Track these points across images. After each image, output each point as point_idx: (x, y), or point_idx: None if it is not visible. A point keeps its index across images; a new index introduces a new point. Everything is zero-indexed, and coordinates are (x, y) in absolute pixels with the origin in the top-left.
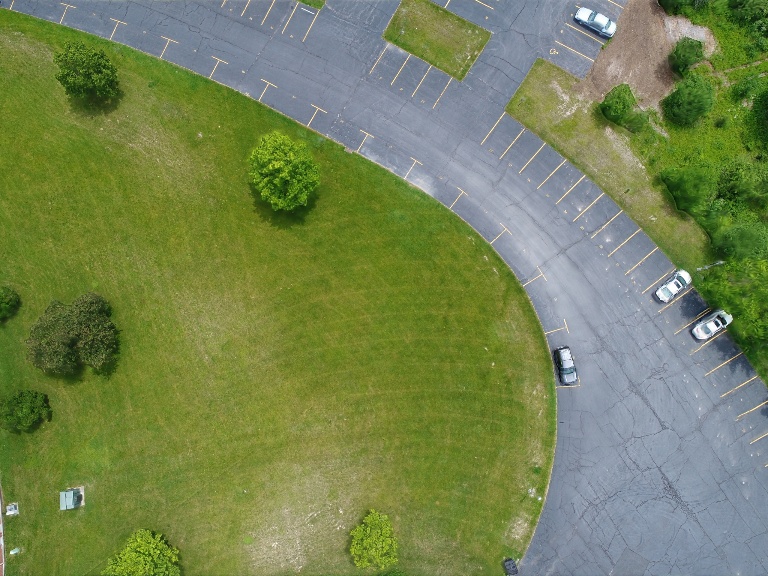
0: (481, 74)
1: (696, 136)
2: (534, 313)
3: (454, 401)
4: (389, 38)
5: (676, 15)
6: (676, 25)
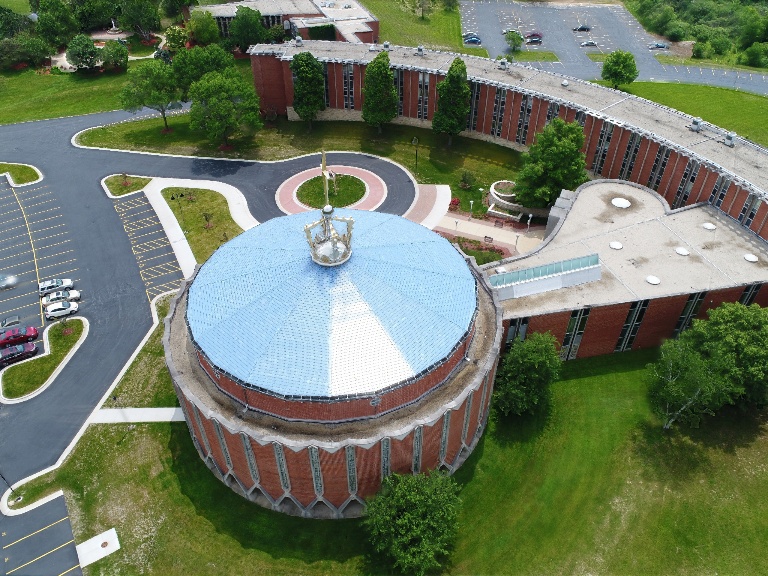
0: (640, 61)
1: (732, 56)
2: (752, 94)
3: (764, 115)
4: (595, 61)
5: (682, 41)
6: (686, 42)
